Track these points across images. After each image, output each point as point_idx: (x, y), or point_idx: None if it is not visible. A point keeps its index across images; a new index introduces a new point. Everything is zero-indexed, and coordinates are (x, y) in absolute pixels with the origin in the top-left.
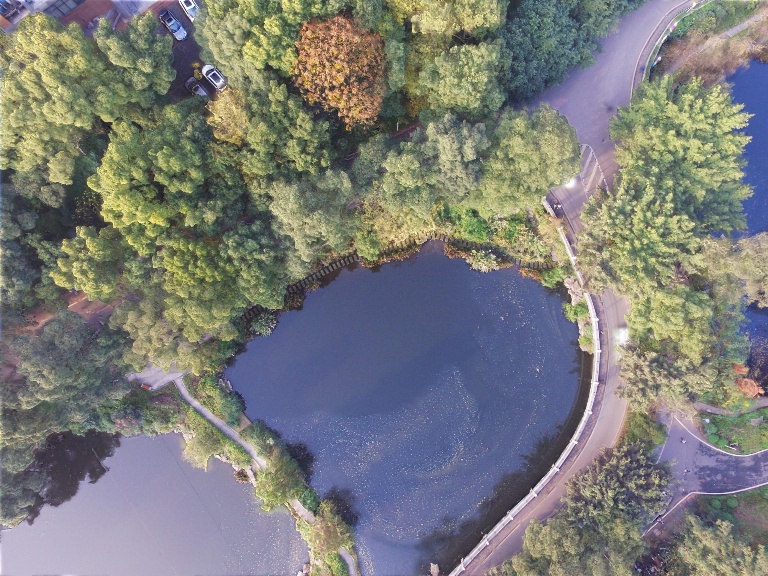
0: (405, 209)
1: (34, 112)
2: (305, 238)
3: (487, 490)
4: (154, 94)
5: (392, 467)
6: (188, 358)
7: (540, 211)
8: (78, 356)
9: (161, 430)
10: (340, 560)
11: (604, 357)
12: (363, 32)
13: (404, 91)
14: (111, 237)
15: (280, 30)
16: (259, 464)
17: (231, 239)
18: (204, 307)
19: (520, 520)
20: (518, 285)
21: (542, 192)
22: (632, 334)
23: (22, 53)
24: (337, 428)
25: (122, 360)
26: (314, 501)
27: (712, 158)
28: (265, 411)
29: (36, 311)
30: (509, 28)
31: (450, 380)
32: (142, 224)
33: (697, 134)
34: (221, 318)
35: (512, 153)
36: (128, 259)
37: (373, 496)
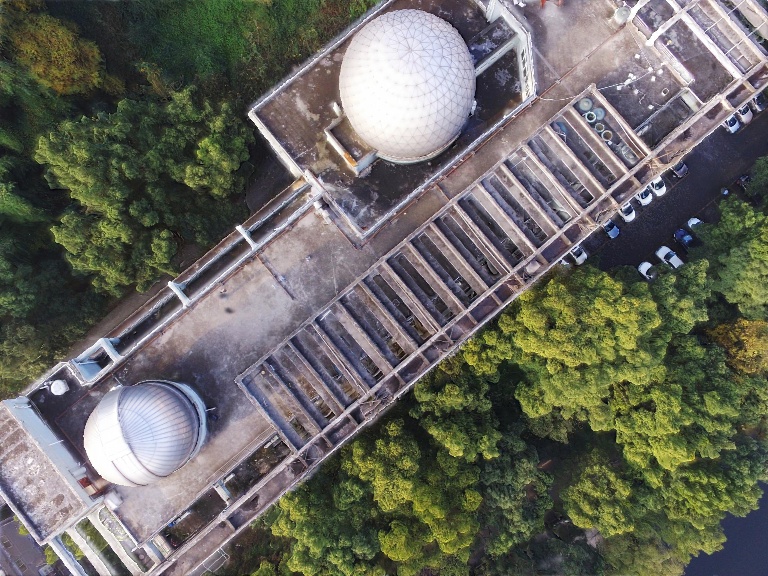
0: None
1: (609, 376)
2: None
3: None
4: None
5: None
6: None
7: None
8: None
9: None
10: None
11: None
12: None
13: None
14: None
15: None
16: None
17: (745, 466)
18: None
19: None
20: None
21: None
22: None
23: (598, 318)
24: None
25: None
26: None
27: None
28: None
29: None
30: None
31: None
32: (654, 456)
33: None
34: None
35: None
36: None
37: None
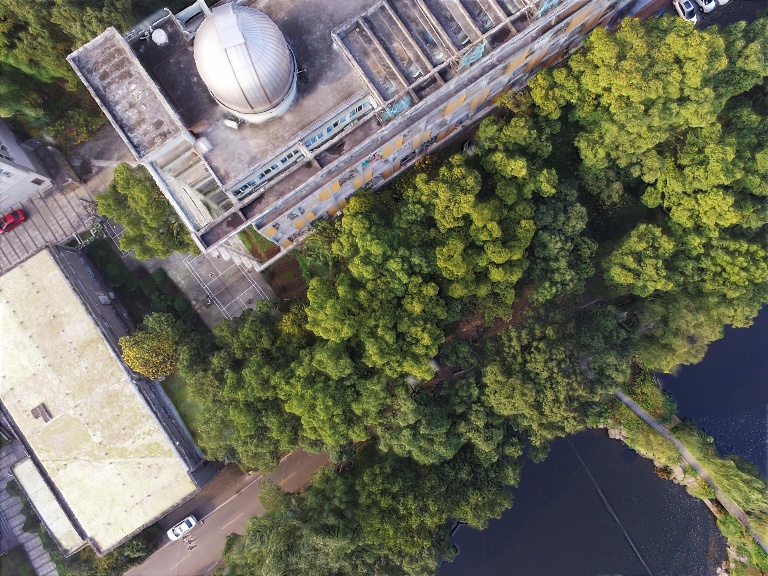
0: None
1: (672, 112)
2: None
3: None
4: None
5: None
6: (691, 356)
7: None
8: None
9: (593, 424)
10: None
11: None
12: None
13: None
14: None
15: None
16: (687, 461)
17: None
18: None
19: None
20: None
21: None
22: None
23: (668, 53)
24: (764, 429)
25: (631, 356)
26: None
27: None
28: (691, 410)
29: None
30: None
31: None
32: (698, 224)
33: None
34: None
35: None
36: None
37: None
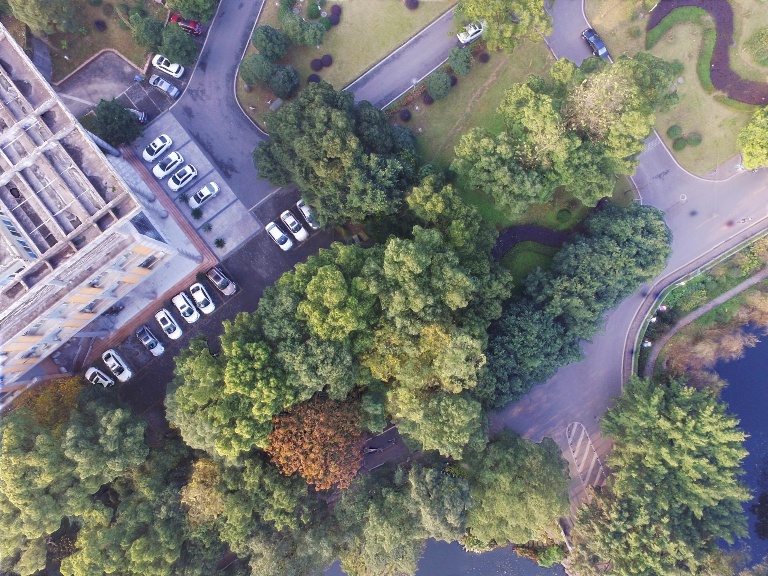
0: (389, 566)
1: None
2: None
3: None
4: None
5: None
6: None
7: None
8: None
9: None
10: None
11: None
12: (338, 415)
13: None
14: None
15: (252, 432)
16: None
17: None
18: None
19: None
20: (513, 565)
21: None
22: None
23: None
24: None
25: None
26: None
27: (708, 469)
28: None
29: None
30: (491, 346)
31: None
32: None
33: None
34: None
35: (498, 512)
36: None
37: None
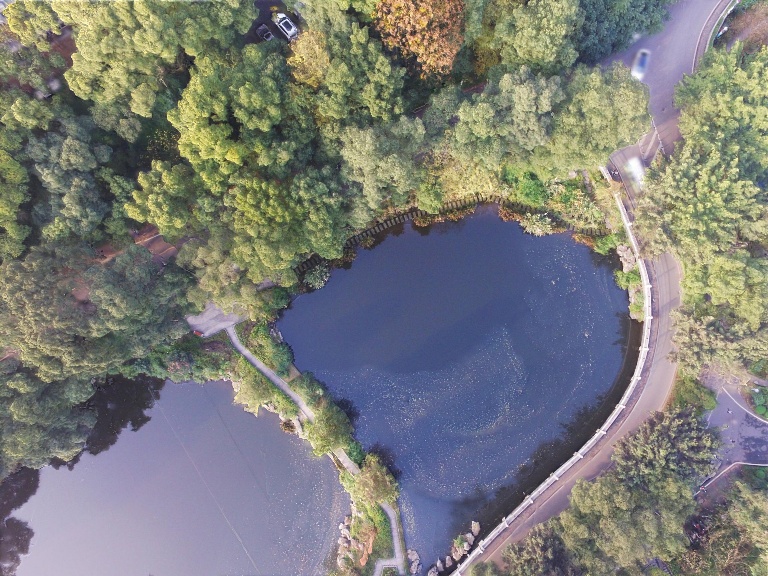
0: (475, 159)
1: (124, 39)
2: (376, 182)
3: (531, 451)
4: (234, 33)
5: (438, 424)
6: (249, 300)
7: (597, 177)
8: (146, 290)
9: (211, 377)
10: (383, 513)
11: (654, 324)
12: None
13: (474, 47)
14: (183, 175)
15: None
16: (306, 415)
17: (303, 180)
18: (272, 247)
19: (564, 481)
20: (570, 250)
21: (609, 151)
22: (687, 300)
23: None
24: (385, 383)
25: (185, 299)
26: (360, 454)
27: None
28: (314, 363)
29: (103, 246)
30: None
31: (499, 341)
32: (216, 162)
33: (764, 102)
34: (287, 260)
35: (586, 107)
36: (200, 196)
37: (418, 452)
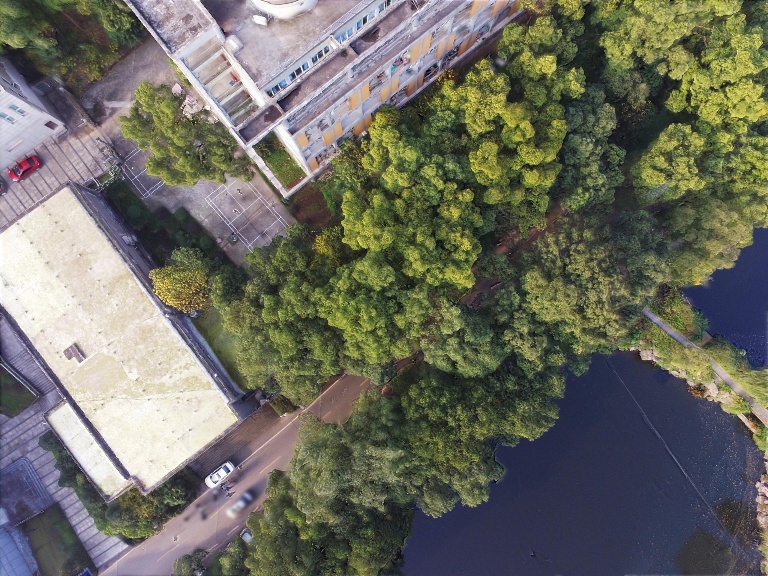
0: None
1: None
2: None
3: None
4: None
5: None
6: None
7: None
8: None
9: (625, 346)
10: None
11: None
12: None
13: None
14: None
15: None
16: (721, 377)
17: None
18: None
19: None
20: None
21: None
22: None
23: None
24: None
25: None
26: None
27: None
28: (721, 326)
29: None
30: None
31: None
32: (726, 122)
33: None
34: None
35: None
36: None
37: None
